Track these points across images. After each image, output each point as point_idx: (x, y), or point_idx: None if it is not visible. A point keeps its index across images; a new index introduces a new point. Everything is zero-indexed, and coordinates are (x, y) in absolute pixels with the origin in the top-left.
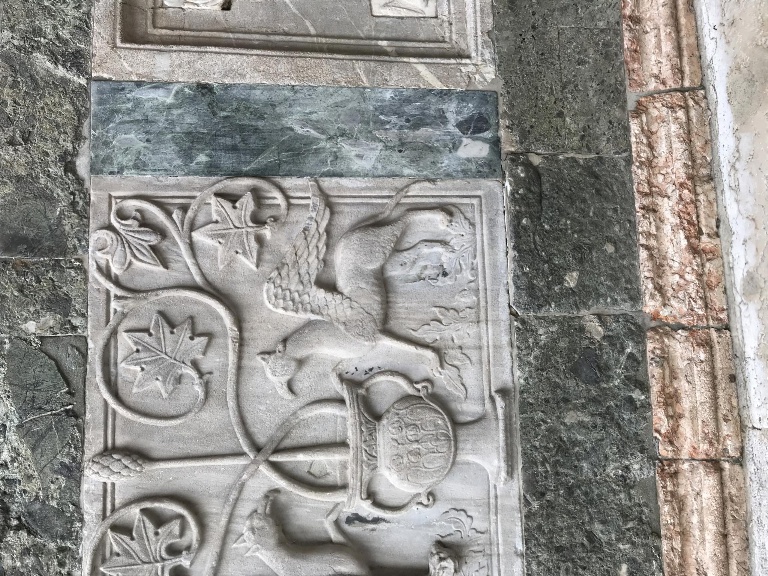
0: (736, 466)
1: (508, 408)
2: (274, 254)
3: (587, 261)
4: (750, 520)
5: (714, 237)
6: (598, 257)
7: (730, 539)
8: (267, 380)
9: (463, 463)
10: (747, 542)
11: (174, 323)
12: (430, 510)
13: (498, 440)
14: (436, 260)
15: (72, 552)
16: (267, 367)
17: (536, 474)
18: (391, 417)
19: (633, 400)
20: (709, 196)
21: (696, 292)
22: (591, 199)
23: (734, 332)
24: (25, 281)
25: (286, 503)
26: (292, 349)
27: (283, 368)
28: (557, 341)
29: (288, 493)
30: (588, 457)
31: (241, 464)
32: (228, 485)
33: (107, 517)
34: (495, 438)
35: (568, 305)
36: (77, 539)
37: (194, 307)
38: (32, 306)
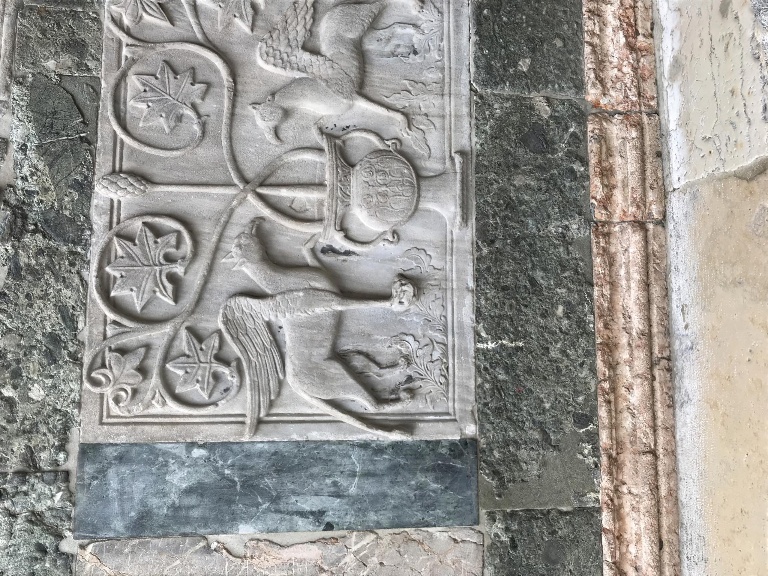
0: (659, 227)
1: (465, 166)
2: (267, 22)
3: (539, 51)
4: (669, 271)
5: (648, 37)
6: (548, 49)
7: (652, 287)
8: (257, 127)
9: (425, 210)
10: (666, 291)
11: (178, 72)
12: (395, 248)
13: (456, 189)
14: (408, 41)
15: (81, 256)
16: (258, 113)
17: (488, 224)
18: (364, 164)
19: (574, 171)
20: (646, 3)
21: (631, 82)
22: (544, 0)
23: (662, 115)
24: (48, 27)
25: (270, 230)
26: (280, 99)
27: (272, 114)
28: (510, 115)
29: (272, 222)
30: (533, 214)
31: (232, 194)
32: (220, 210)
33: (113, 228)
34: (453, 188)
35: (521, 86)
36: (86, 245)
37: (196, 60)
38: (54, 48)
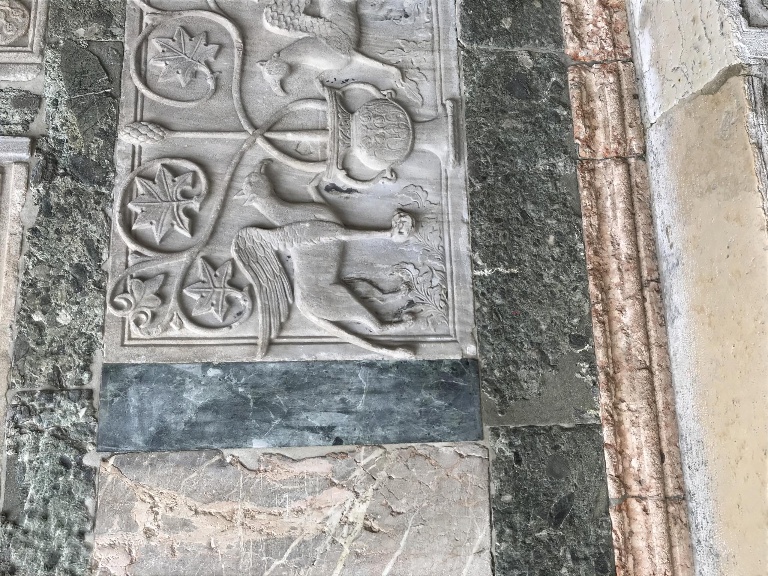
0: (640, 161)
1: (456, 111)
2: None
3: (519, 11)
4: (653, 201)
5: None
6: (528, 10)
7: (637, 216)
8: (264, 81)
9: (420, 151)
10: (651, 219)
11: (192, 35)
12: (393, 185)
13: (447, 131)
14: (399, 6)
15: (106, 195)
16: (264, 68)
17: (479, 163)
18: (362, 110)
19: (557, 115)
20: None
21: (606, 34)
22: None
23: (636, 61)
24: (77, 1)
25: (277, 171)
26: (284, 55)
27: (277, 68)
28: (495, 67)
29: (279, 163)
30: (521, 154)
31: (242, 139)
32: (231, 154)
33: None
34: (445, 130)
35: (504, 41)
36: (110, 186)
37: (208, 25)
38: (82, 18)
